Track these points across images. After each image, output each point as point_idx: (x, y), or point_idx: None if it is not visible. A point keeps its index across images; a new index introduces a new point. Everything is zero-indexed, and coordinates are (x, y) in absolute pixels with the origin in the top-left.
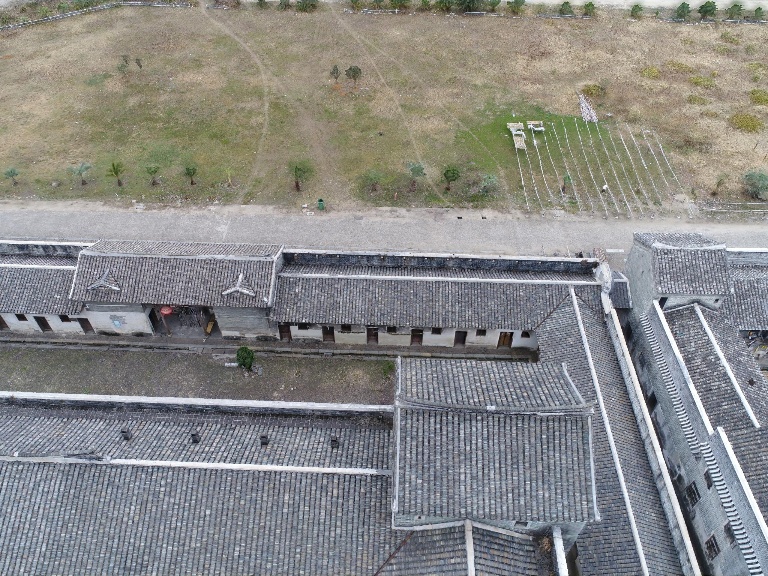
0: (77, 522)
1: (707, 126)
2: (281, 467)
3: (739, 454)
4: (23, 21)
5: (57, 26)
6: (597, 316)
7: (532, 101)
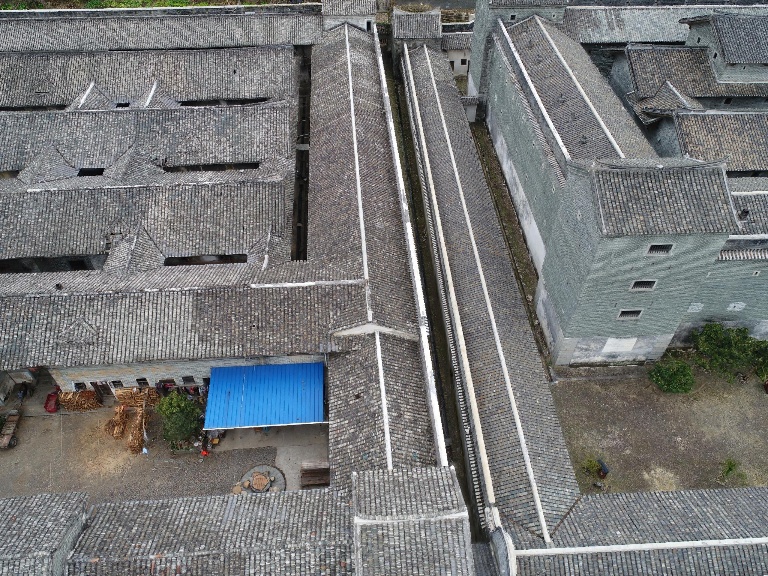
0: None
1: None
2: (767, 192)
3: (404, 315)
4: None
5: None
6: (506, 514)
7: None
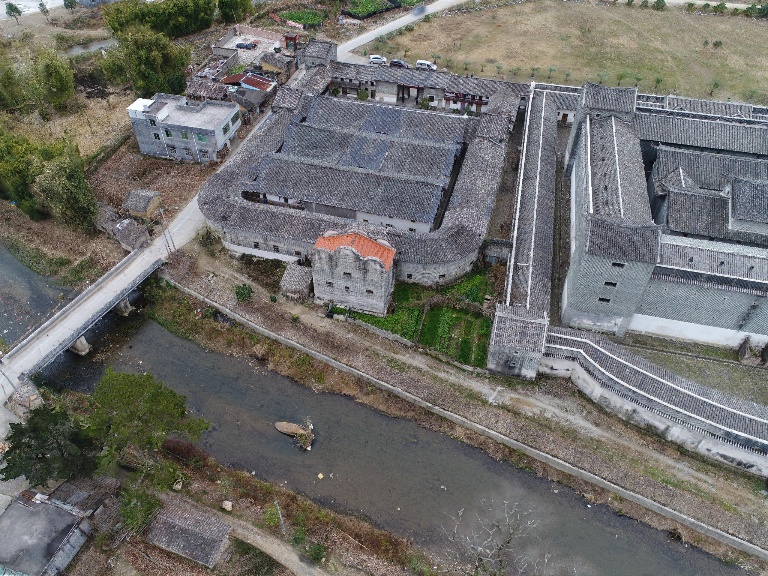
0: (767, 142)
1: None
2: None
3: None
4: (497, 4)
5: (515, 8)
6: None
7: None
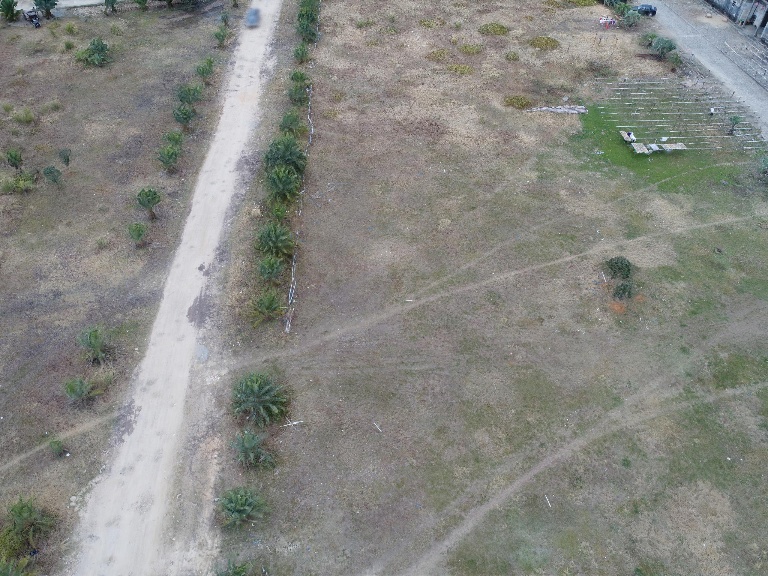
0: None
1: (560, 59)
2: None
3: None
4: None
5: None
6: None
7: (561, 139)
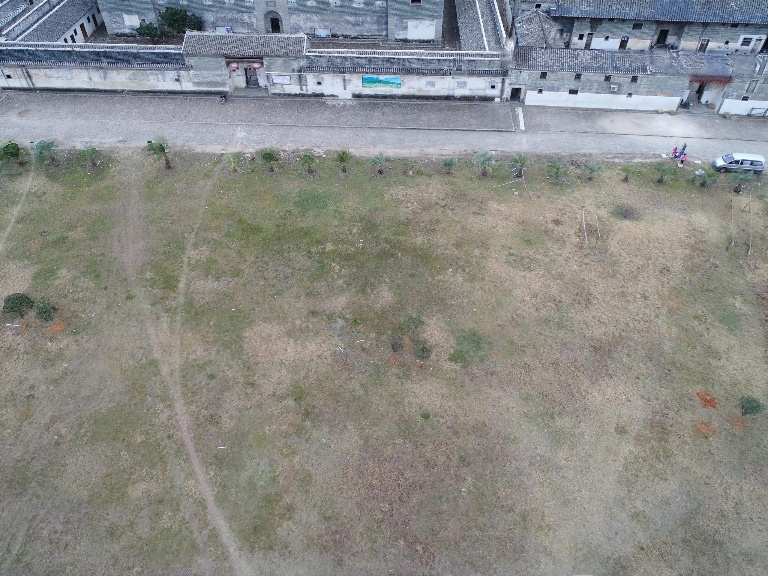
0: None
1: None
2: None
3: None
4: None
5: None
6: None
7: None
